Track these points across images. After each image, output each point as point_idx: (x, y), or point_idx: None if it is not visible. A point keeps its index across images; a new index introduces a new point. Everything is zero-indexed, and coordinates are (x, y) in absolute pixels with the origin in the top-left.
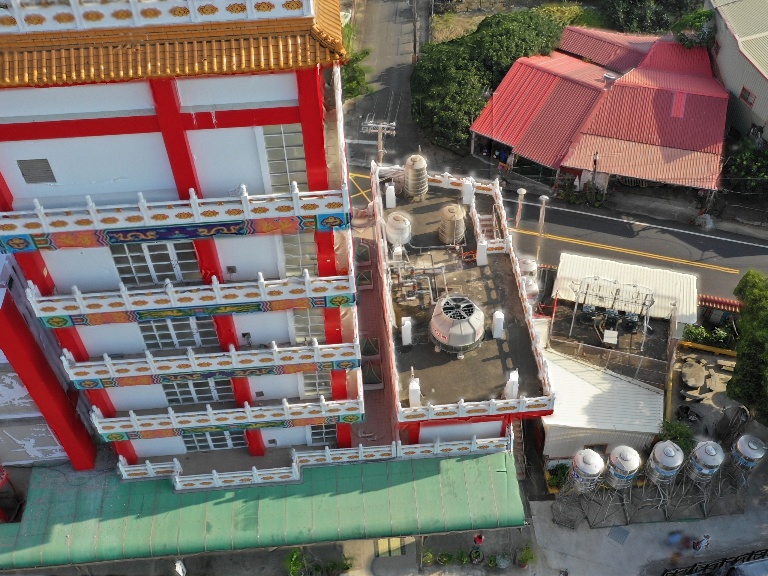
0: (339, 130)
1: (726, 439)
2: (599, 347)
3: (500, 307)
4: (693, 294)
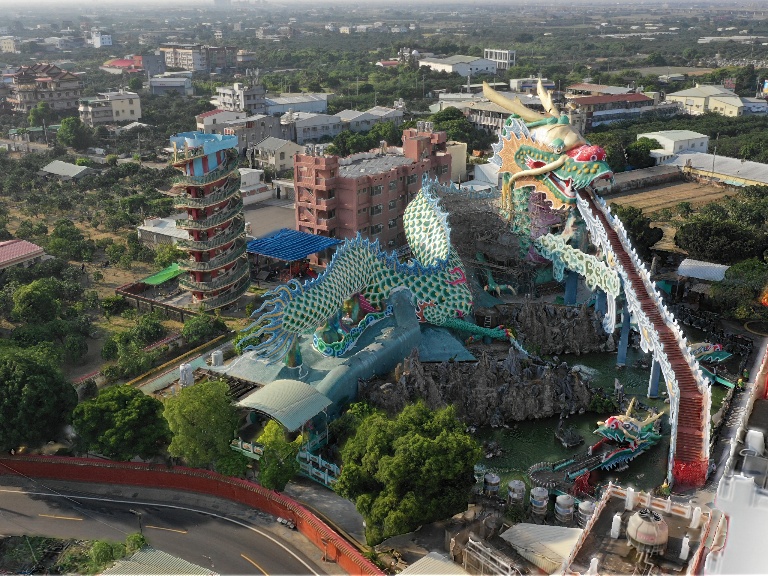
0: (764, 366)
1: (470, 527)
2: (515, 568)
3: (602, 547)
4: (411, 568)
